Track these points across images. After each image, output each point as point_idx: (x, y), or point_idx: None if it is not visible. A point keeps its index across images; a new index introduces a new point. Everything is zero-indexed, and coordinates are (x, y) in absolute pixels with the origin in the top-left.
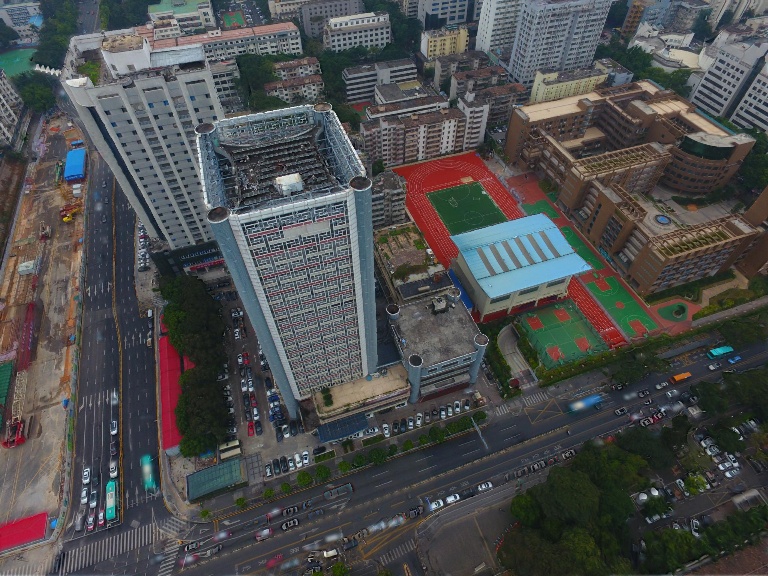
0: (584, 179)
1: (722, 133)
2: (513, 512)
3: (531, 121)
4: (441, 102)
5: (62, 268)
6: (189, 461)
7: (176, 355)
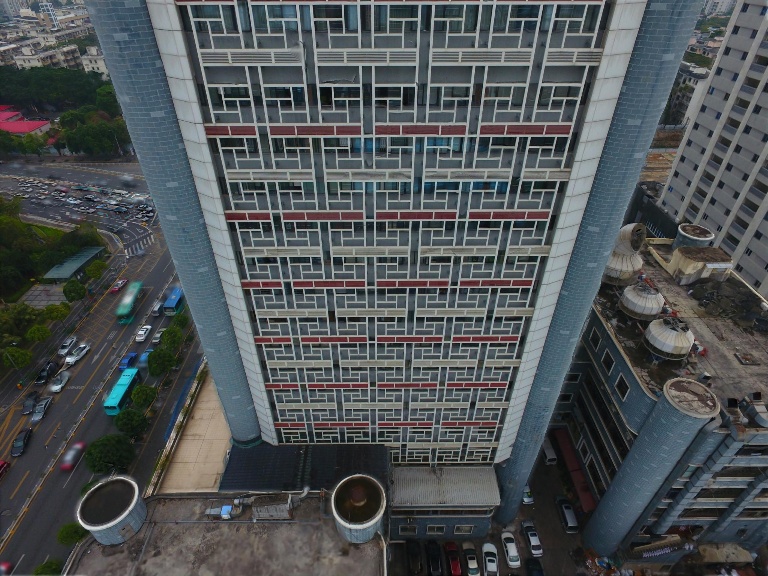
0: None
1: None
2: None
3: None
4: None
5: None
6: None
7: None
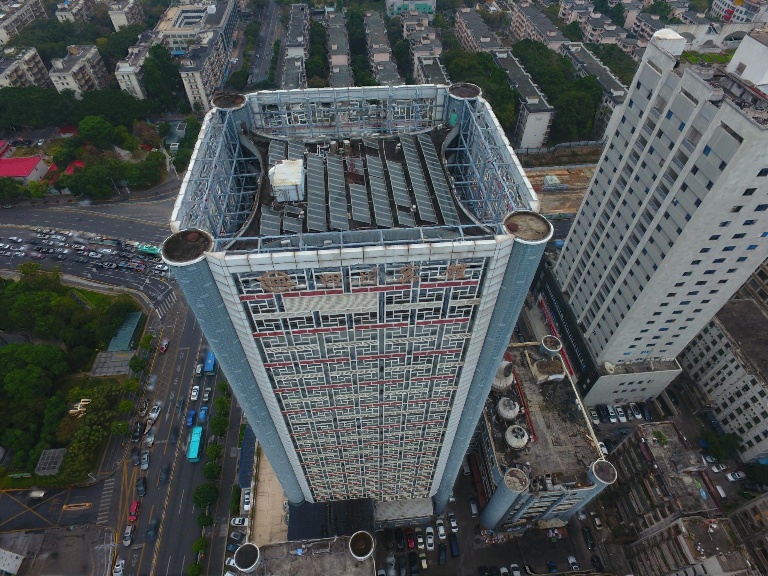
0: None
1: None
2: None
3: None
4: None
5: (554, 204)
6: None
7: None
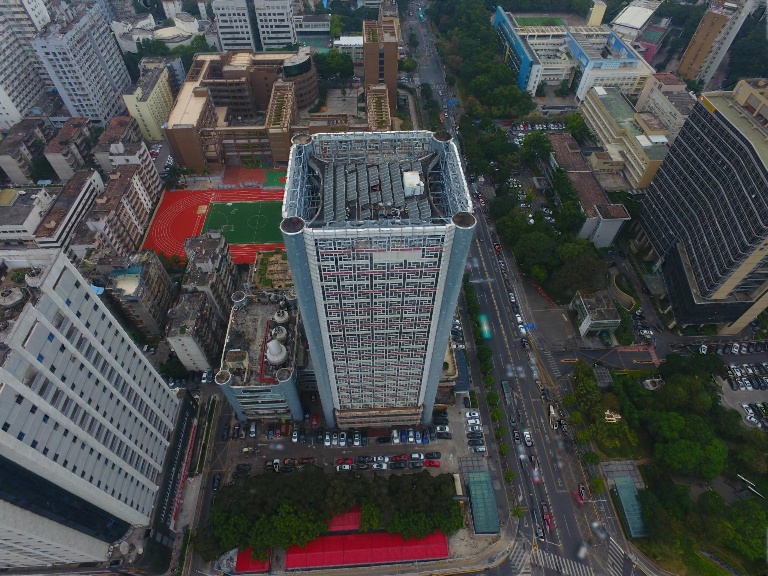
0: (287, 130)
1: (288, 55)
2: (542, 279)
3: (195, 126)
4: (90, 175)
5: None
6: (457, 534)
7: (321, 541)
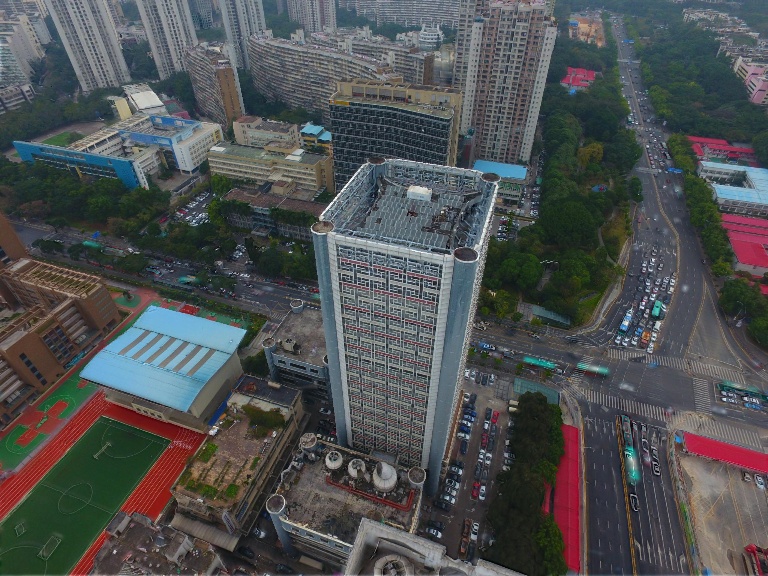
0: None
1: None
2: None
3: None
4: None
5: None
6: None
7: None
